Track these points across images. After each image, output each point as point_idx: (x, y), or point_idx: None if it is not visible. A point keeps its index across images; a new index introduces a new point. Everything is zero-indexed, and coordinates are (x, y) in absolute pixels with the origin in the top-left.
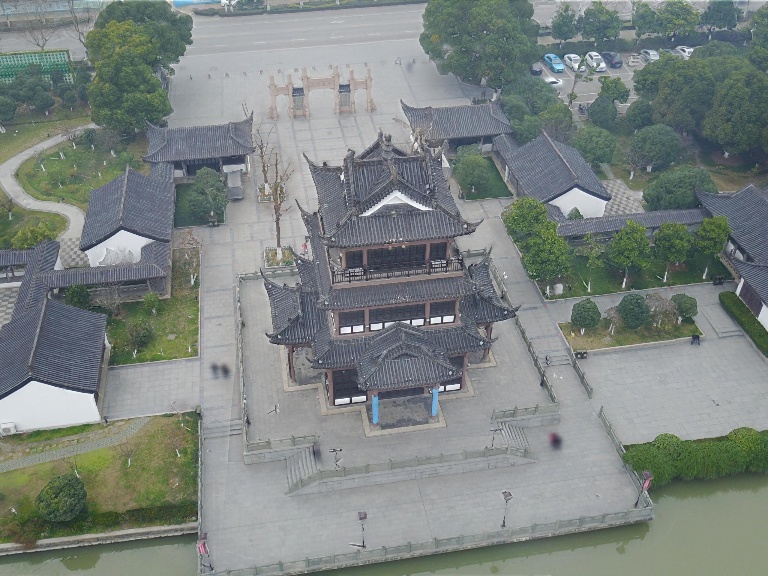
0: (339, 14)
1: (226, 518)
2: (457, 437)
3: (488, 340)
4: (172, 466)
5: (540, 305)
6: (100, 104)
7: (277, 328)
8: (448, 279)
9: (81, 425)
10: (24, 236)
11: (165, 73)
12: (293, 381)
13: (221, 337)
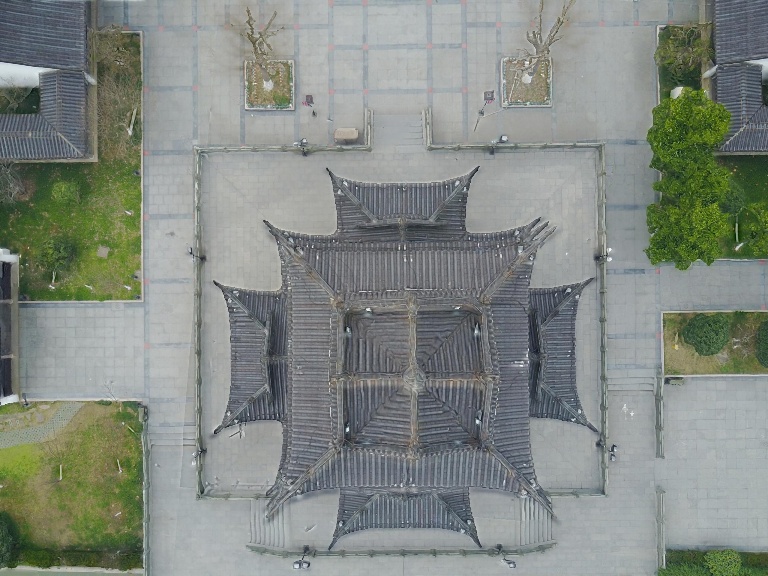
0: None
1: (177, 569)
2: None
3: None
4: (113, 485)
5: (651, 267)
6: None
7: (236, 387)
8: None
9: None
10: None
11: None
12: None
13: (173, 262)
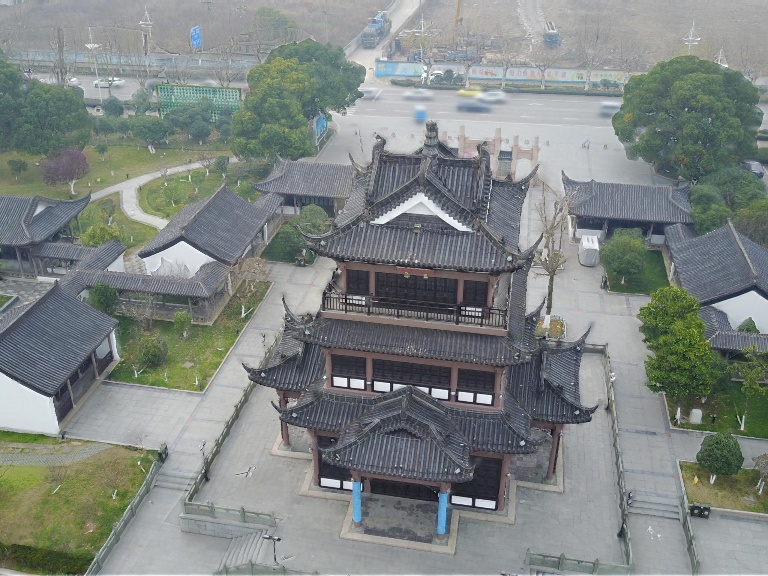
0: (540, 98)
1: None
2: (463, 573)
3: (532, 440)
4: (99, 507)
5: (661, 431)
6: (239, 132)
7: None
8: (485, 338)
9: (36, 434)
10: (93, 233)
11: (322, 118)
12: (285, 443)
13: (240, 378)
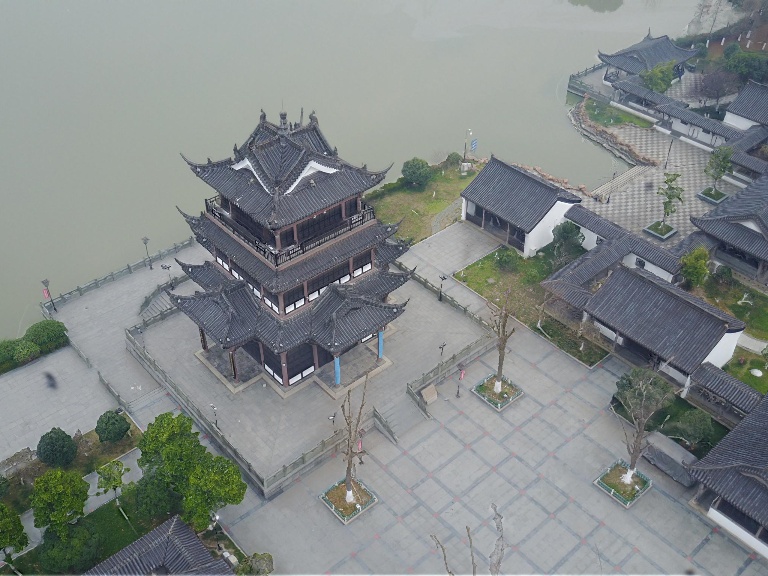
0: None
1: None
2: None
3: None
4: (388, 220)
5: None
6: None
7: None
8: None
9: None
10: None
11: None
12: None
13: (455, 297)
